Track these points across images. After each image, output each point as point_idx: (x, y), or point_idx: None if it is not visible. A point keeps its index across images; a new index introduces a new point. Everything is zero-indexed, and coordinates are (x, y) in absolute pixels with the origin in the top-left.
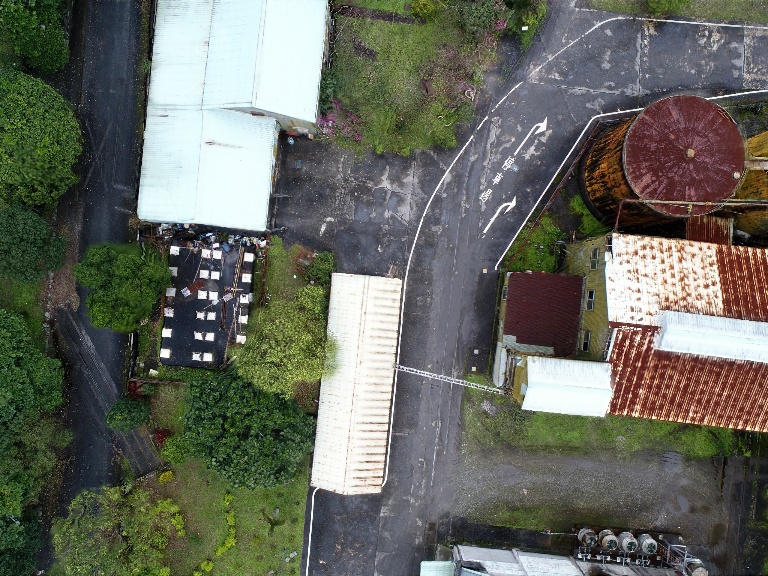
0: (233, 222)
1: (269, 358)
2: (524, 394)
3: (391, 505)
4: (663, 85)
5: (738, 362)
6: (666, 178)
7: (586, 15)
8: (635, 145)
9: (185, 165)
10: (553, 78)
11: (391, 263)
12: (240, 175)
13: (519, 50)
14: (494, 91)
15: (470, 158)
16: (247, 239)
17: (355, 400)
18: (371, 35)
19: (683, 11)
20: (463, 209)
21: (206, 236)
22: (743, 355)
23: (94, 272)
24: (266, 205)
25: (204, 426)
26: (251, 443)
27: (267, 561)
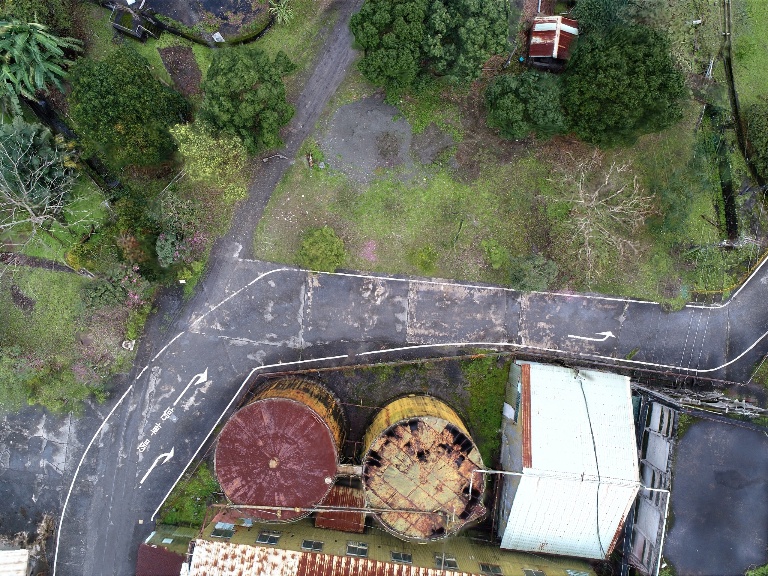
0: None
1: None
2: None
3: None
4: (325, 338)
5: None
6: (255, 483)
7: (250, 266)
8: (227, 448)
9: None
10: (215, 328)
11: (45, 513)
12: None
13: (181, 300)
14: (155, 340)
15: (128, 408)
16: None
17: None
18: (30, 283)
19: (347, 264)
20: (120, 459)
21: None
22: None
23: None
24: None
25: None
26: None
27: None
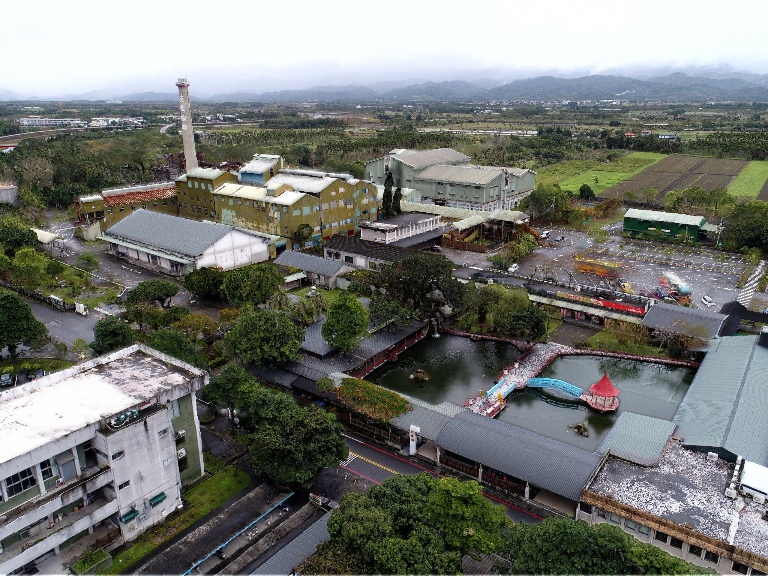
0: None
1: None
2: (81, 200)
3: None
4: None
5: (126, 194)
6: None
7: None
8: None
9: None
10: None
11: None
12: None
13: None
14: None
15: None
16: None
17: None
18: None
19: None
20: None
21: None
22: (123, 190)
23: None
24: None
25: (0, 231)
26: None
27: None
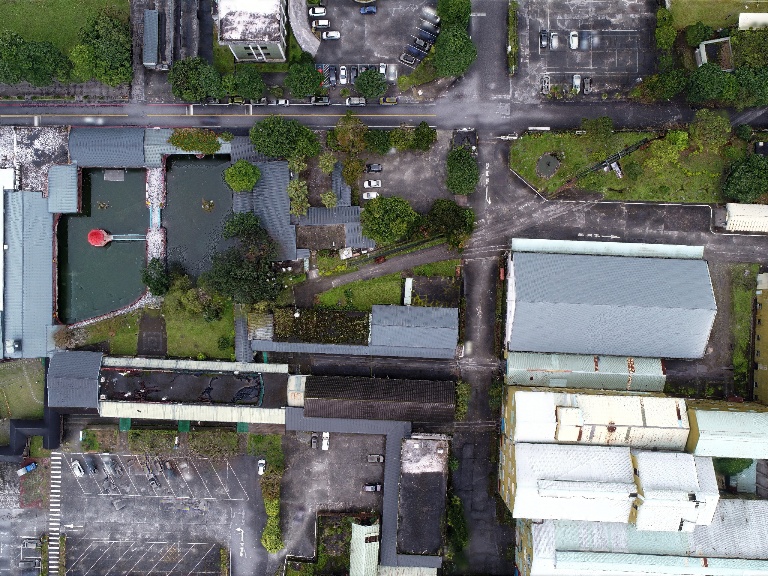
0: None
1: None
2: None
3: (706, 237)
4: None
5: None
6: None
7: None
8: None
9: None
10: None
11: None
12: None
13: None
14: None
15: None
16: None
17: (765, 217)
18: None
19: None
20: None
21: None
22: None
23: None
24: None
25: None
26: (759, 180)
27: None
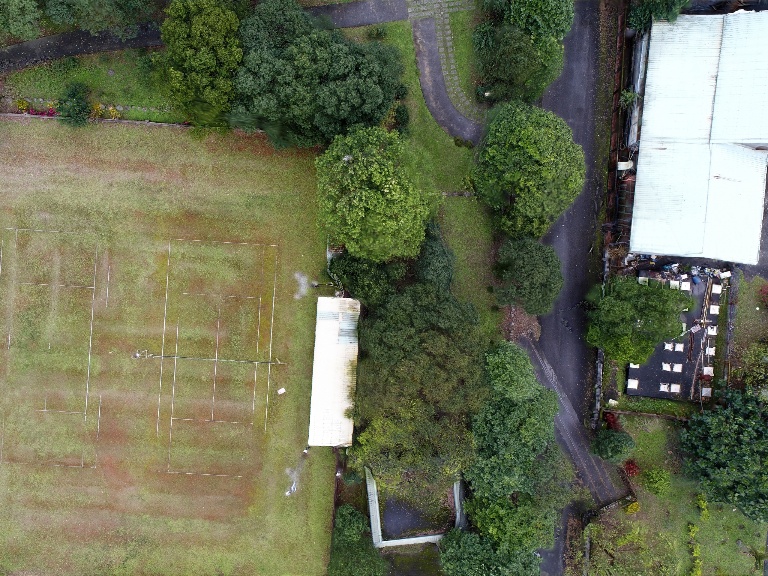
0: (732, 256)
1: None
2: None
3: None
4: None
5: None
6: None
7: None
8: None
9: (689, 199)
10: None
11: None
12: (739, 209)
13: None
14: None
15: None
16: (709, 270)
17: None
18: None
19: None
20: None
21: (671, 267)
22: None
23: (629, 306)
24: (758, 239)
25: (748, 462)
26: None
27: None
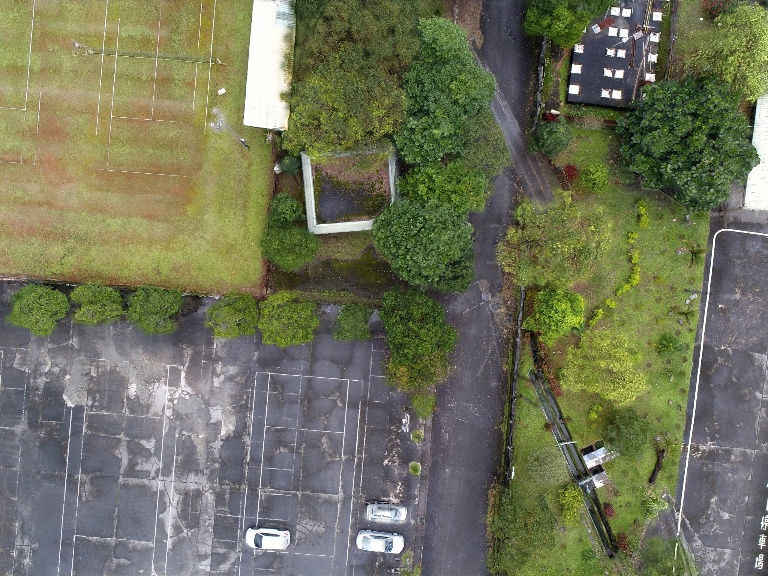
0: None
1: (760, 45)
2: None
3: None
4: None
5: None
6: None
7: None
8: None
9: None
10: None
11: None
12: None
13: None
14: None
15: None
16: None
17: None
18: None
19: None
20: None
21: None
22: None
23: None
24: None
25: (679, 120)
26: (725, 139)
27: (666, 303)
